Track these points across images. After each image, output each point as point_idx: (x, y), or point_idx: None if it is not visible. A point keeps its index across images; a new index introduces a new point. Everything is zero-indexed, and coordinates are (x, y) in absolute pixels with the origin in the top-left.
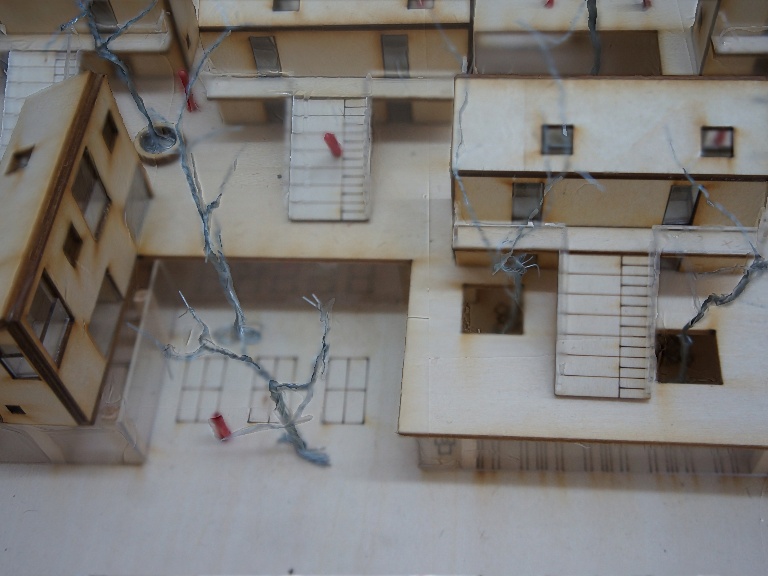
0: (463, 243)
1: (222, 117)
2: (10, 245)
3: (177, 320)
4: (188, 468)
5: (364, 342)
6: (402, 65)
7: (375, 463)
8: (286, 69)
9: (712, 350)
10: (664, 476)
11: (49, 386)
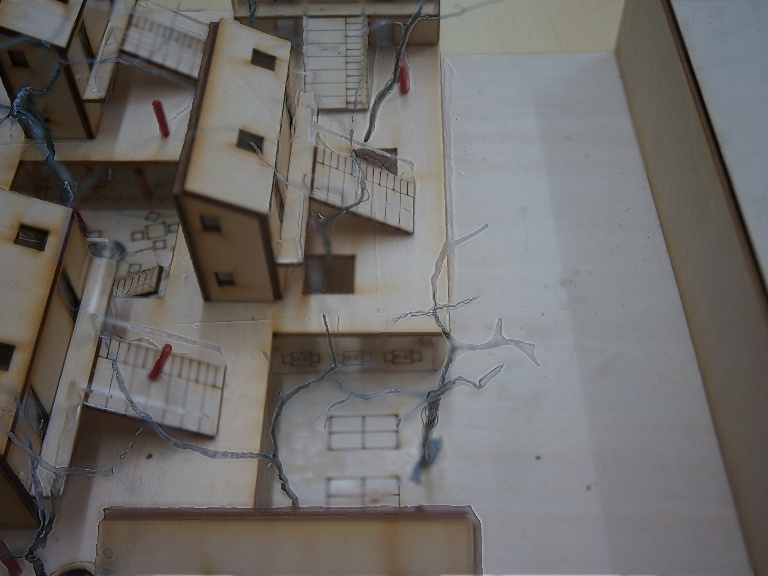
0: None
1: None
2: (373, 549)
3: None
4: None
5: (312, 422)
6: (69, 301)
7: None
8: (46, 406)
9: (367, 153)
10: None
11: None
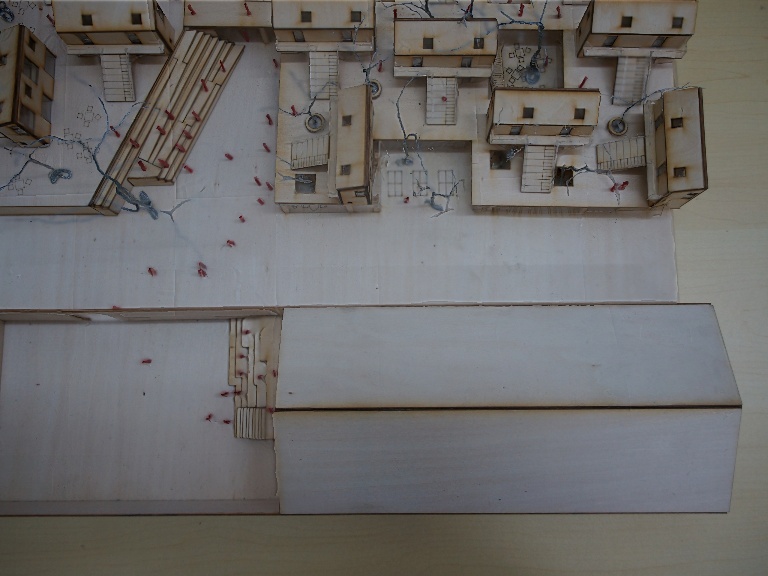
0: (494, 143)
1: (394, 77)
2: (357, 159)
3: (384, 159)
4: (396, 213)
5: (450, 164)
6: (468, 63)
7: (458, 209)
8: (424, 65)
9: (571, 174)
10: (552, 214)
11: (366, 198)
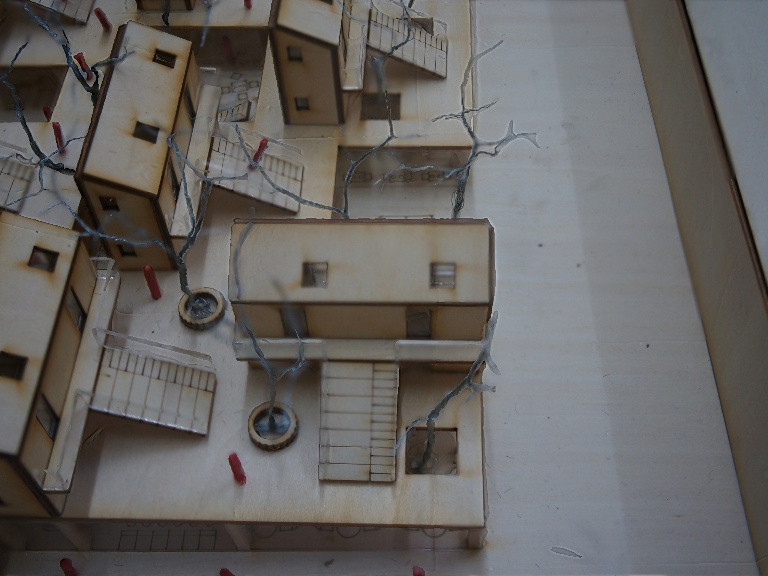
0: None
1: None
2: (419, 243)
3: None
4: None
5: None
6: (188, 112)
7: None
8: (178, 179)
9: None
10: None
11: None
